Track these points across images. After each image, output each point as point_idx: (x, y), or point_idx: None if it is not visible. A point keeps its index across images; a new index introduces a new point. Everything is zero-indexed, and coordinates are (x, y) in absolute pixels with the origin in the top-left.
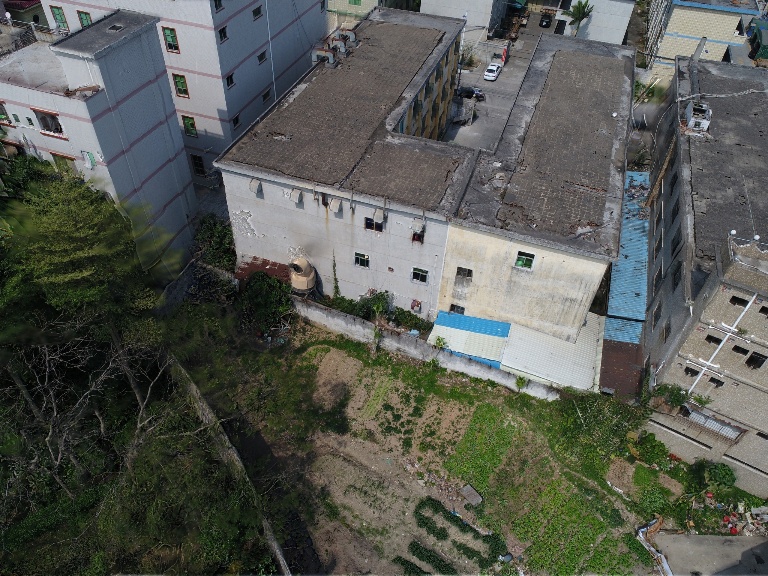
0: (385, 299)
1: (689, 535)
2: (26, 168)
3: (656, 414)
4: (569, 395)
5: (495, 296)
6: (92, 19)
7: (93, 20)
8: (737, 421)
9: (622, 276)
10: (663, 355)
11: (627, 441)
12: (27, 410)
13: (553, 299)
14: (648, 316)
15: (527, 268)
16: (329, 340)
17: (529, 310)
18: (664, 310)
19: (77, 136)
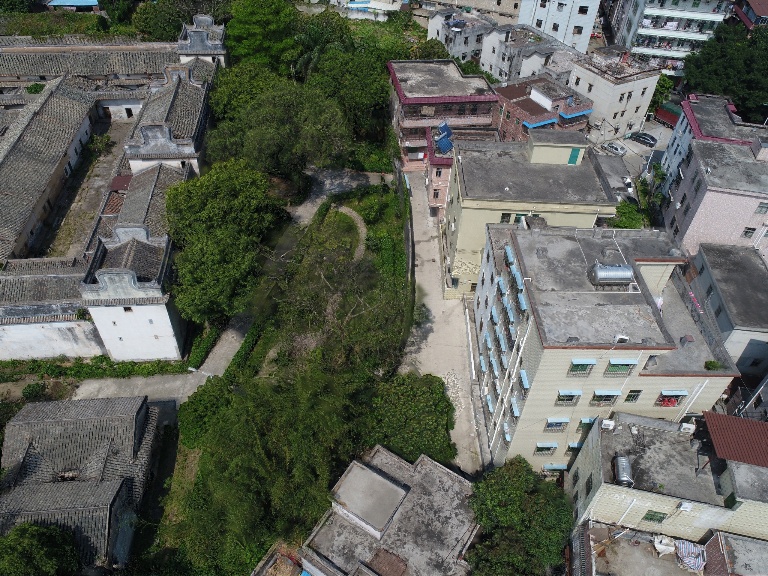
0: None
1: None
2: None
3: (414, 11)
4: (389, 11)
5: None
6: None
7: None
8: (432, 1)
9: None
10: None
11: (409, 26)
12: (230, 3)
13: None
14: None
15: None
16: None
17: None
18: None
19: None
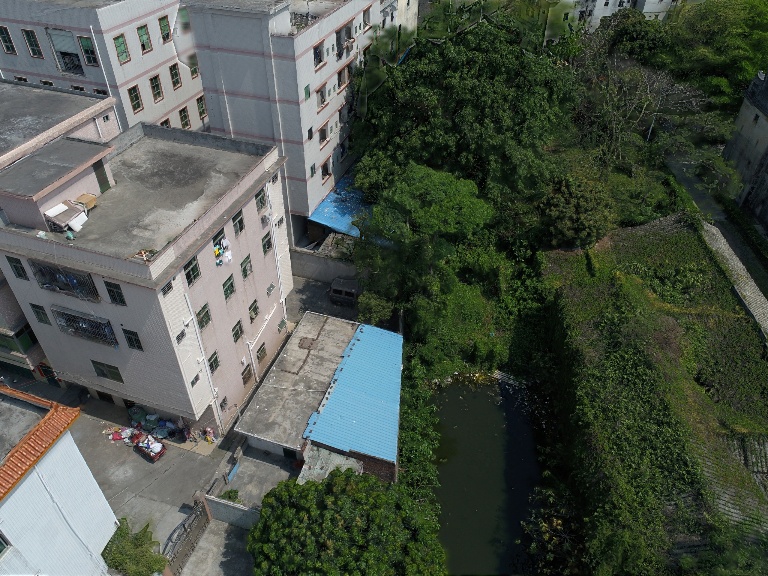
0: None
1: None
2: (351, 84)
3: None
4: None
5: None
6: (148, 30)
7: (149, 31)
8: None
9: None
10: (445, 5)
11: None
12: None
13: None
14: None
15: (408, 7)
16: None
17: None
18: (420, 1)
19: (374, 19)
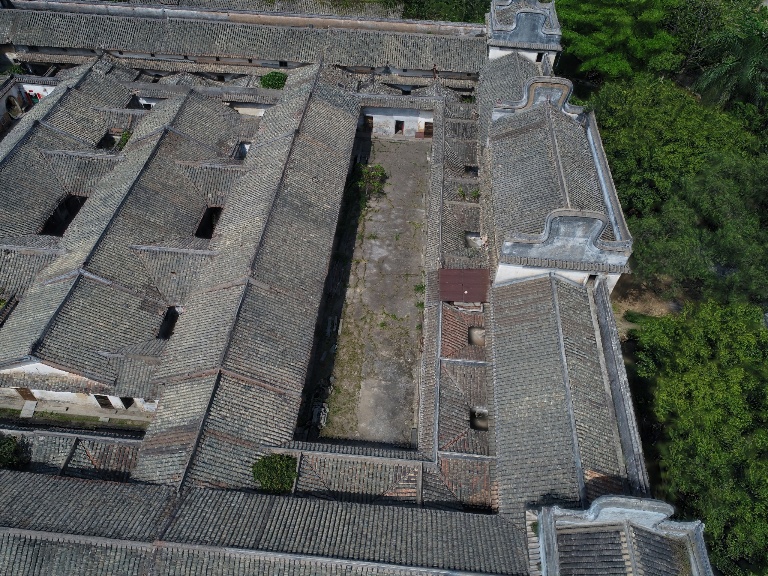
0: None
1: None
2: None
3: None
4: None
5: None
6: None
7: None
8: None
9: None
10: None
11: None
12: None
13: None
14: None
15: None
16: None
17: None
18: None
19: None
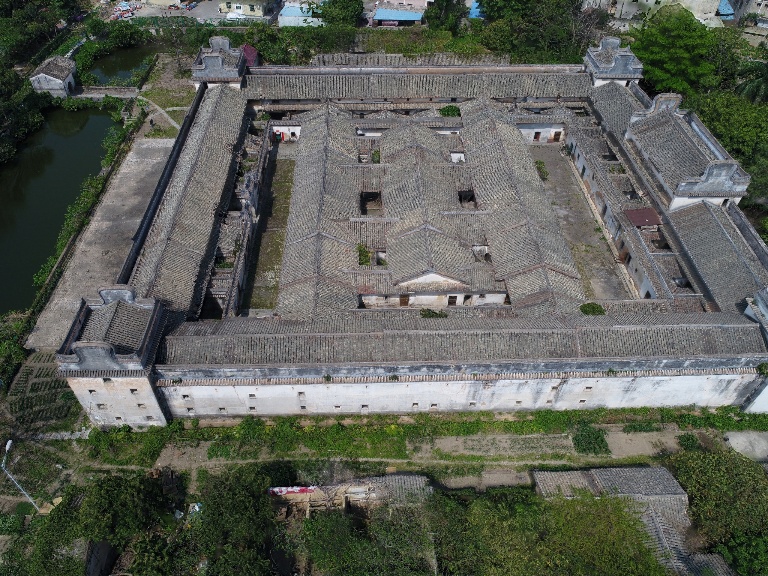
0: (644, 13)
1: (761, 59)
2: None
3: (746, 28)
4: (717, 28)
5: (686, 5)
6: None
7: None
8: None
9: (721, 6)
10: (748, 7)
11: (736, 44)
12: None
13: (708, 1)
14: (735, 11)
15: None
16: (621, 34)
17: (698, 8)
18: None
19: None
